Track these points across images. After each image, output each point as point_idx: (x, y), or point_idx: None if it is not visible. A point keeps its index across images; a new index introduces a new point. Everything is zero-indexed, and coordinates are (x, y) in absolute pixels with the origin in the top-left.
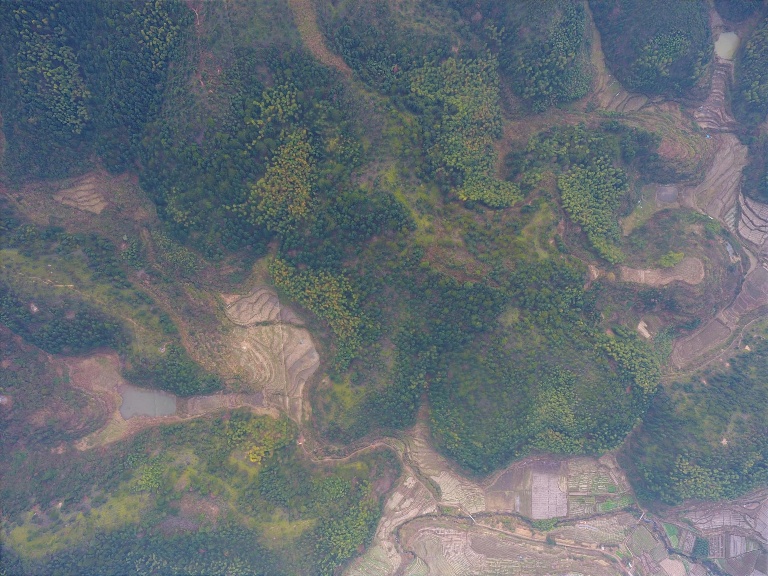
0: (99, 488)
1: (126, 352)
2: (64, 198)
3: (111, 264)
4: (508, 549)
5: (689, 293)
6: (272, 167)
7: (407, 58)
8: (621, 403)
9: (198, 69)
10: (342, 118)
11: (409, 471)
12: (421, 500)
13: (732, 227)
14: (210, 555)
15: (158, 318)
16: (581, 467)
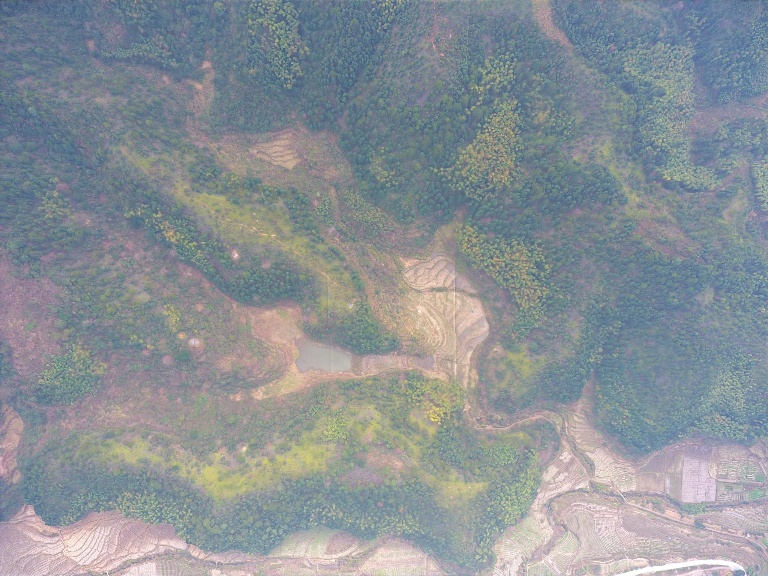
0: (282, 436)
1: (312, 306)
2: (259, 152)
3: (309, 218)
4: (657, 529)
5: None
6: (481, 134)
7: (624, 38)
8: None
9: (431, 32)
10: (557, 91)
11: (565, 445)
12: (575, 475)
13: None
14: (383, 510)
15: (349, 274)
16: (732, 454)
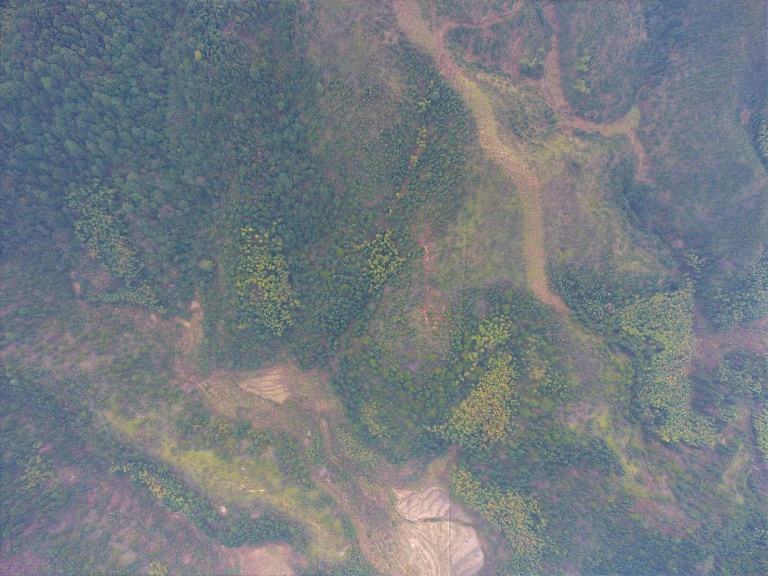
0: None
1: None
2: (249, 386)
3: (299, 465)
4: None
5: None
6: (476, 391)
7: None
8: None
9: (424, 305)
10: (553, 352)
11: None
12: None
13: None
14: None
15: (340, 521)
16: None
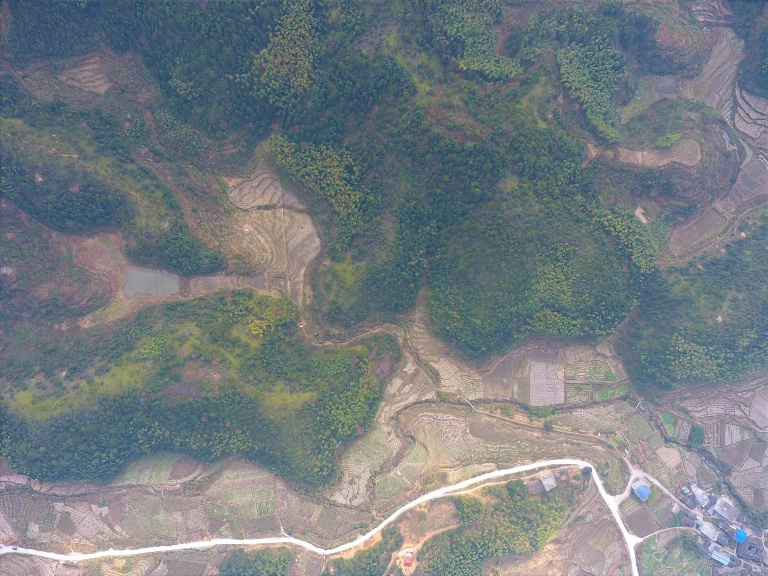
0: (102, 359)
1: (129, 229)
2: (68, 78)
3: (115, 138)
4: (506, 434)
5: (686, 175)
6: (275, 37)
7: None
8: (618, 280)
9: None
10: None
11: (409, 357)
12: (420, 386)
13: (728, 120)
14: (212, 427)
15: (161, 193)
16: (578, 355)
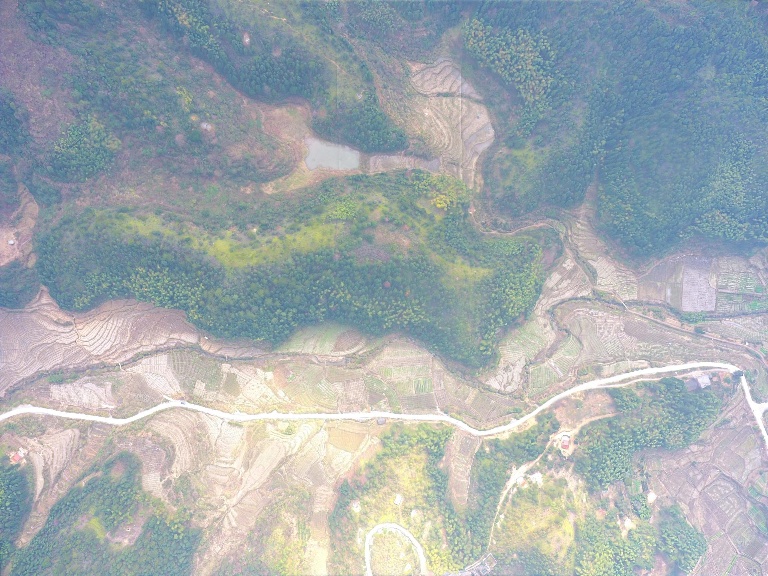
0: (291, 220)
1: (321, 99)
2: None
3: (318, 8)
4: (658, 336)
5: None
6: None
7: None
8: None
9: None
10: None
11: (568, 253)
12: (578, 282)
13: None
14: (390, 295)
15: (357, 66)
16: (731, 266)
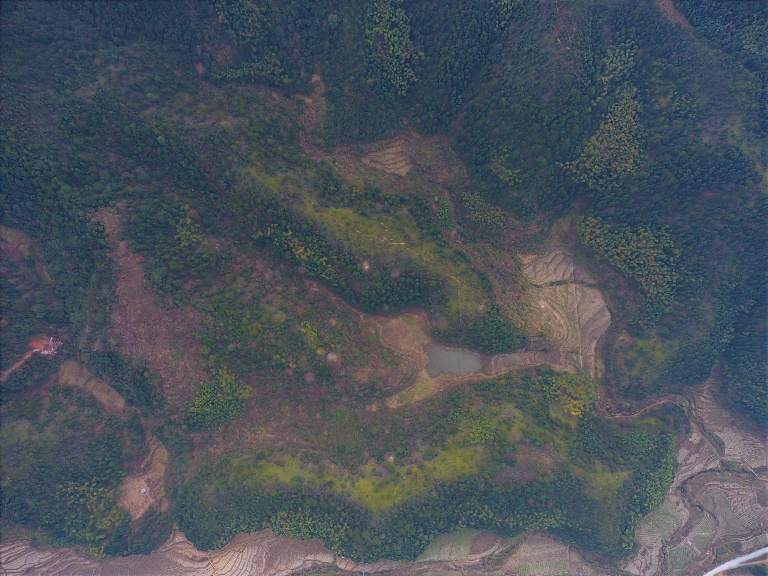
0: (426, 442)
1: (440, 310)
2: (372, 161)
3: (433, 223)
4: None
5: None
6: (604, 125)
7: (741, 16)
8: None
9: (555, 27)
10: (678, 75)
11: (694, 427)
12: (706, 455)
13: None
14: (531, 507)
15: (476, 276)
16: None
